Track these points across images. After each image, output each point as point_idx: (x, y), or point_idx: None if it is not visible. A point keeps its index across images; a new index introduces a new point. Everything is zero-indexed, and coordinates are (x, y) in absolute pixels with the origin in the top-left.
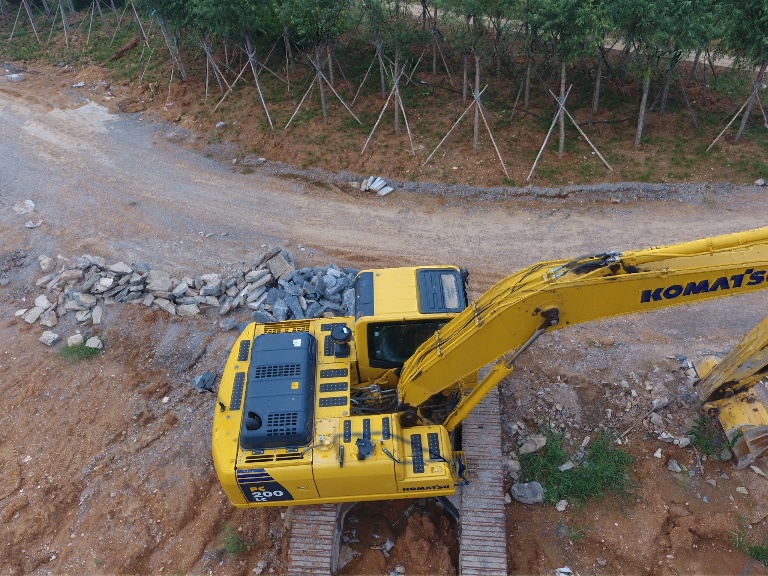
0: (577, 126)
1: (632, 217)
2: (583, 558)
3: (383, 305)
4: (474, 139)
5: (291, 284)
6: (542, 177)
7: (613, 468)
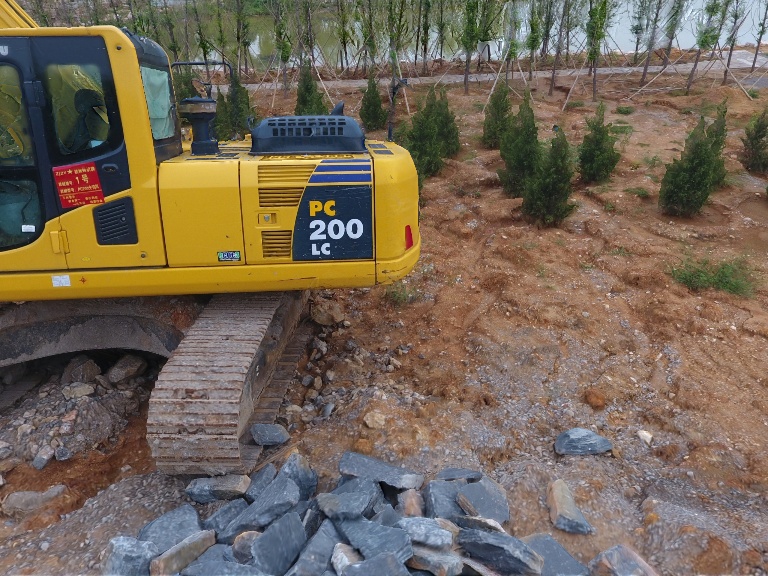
0: None
1: None
2: None
3: None
4: None
5: None
6: None
7: None
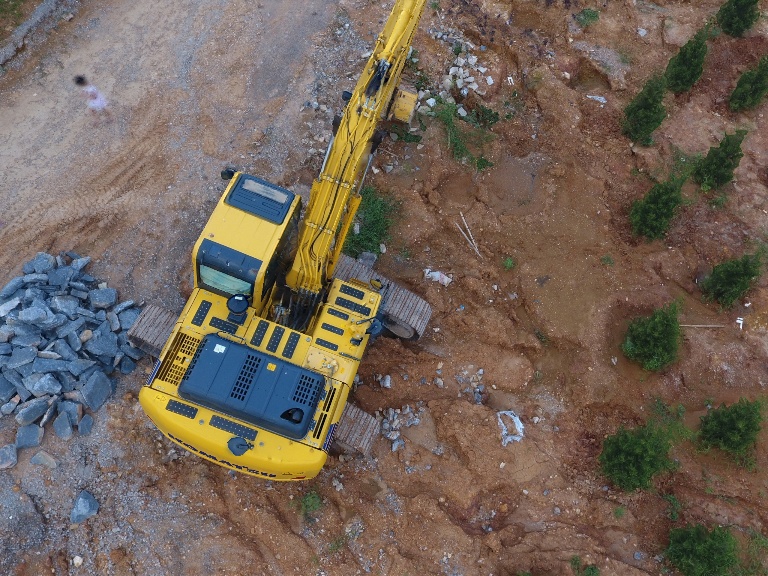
0: None
1: (107, 23)
2: (420, 258)
3: (254, 249)
4: None
5: (4, 359)
6: None
7: None
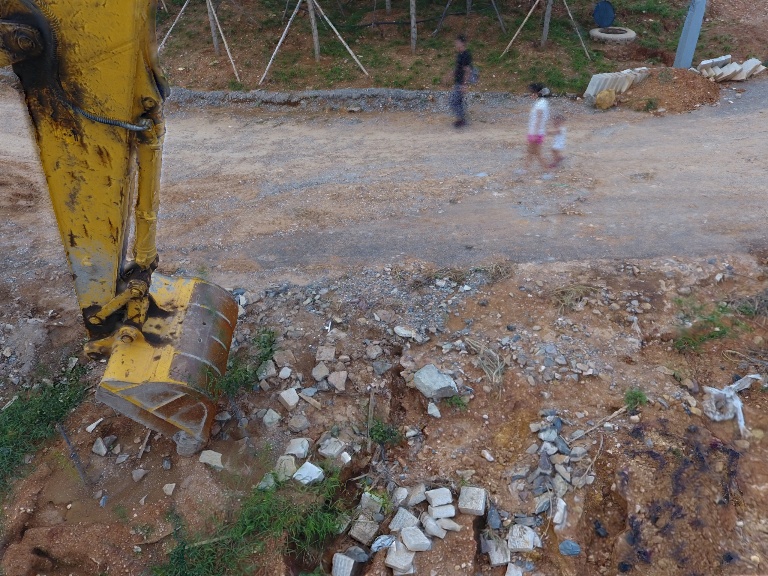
0: (325, 16)
1: (356, 127)
2: None
3: None
4: (212, 35)
5: None
6: (278, 81)
7: (3, 444)
